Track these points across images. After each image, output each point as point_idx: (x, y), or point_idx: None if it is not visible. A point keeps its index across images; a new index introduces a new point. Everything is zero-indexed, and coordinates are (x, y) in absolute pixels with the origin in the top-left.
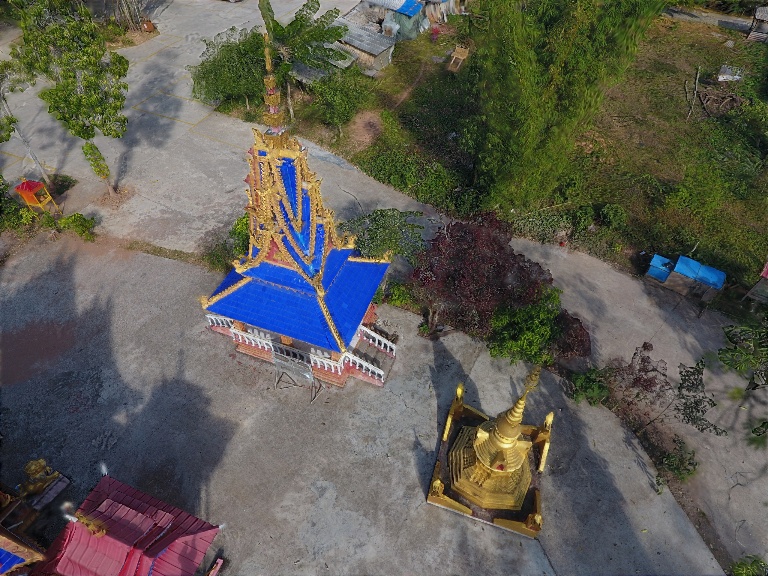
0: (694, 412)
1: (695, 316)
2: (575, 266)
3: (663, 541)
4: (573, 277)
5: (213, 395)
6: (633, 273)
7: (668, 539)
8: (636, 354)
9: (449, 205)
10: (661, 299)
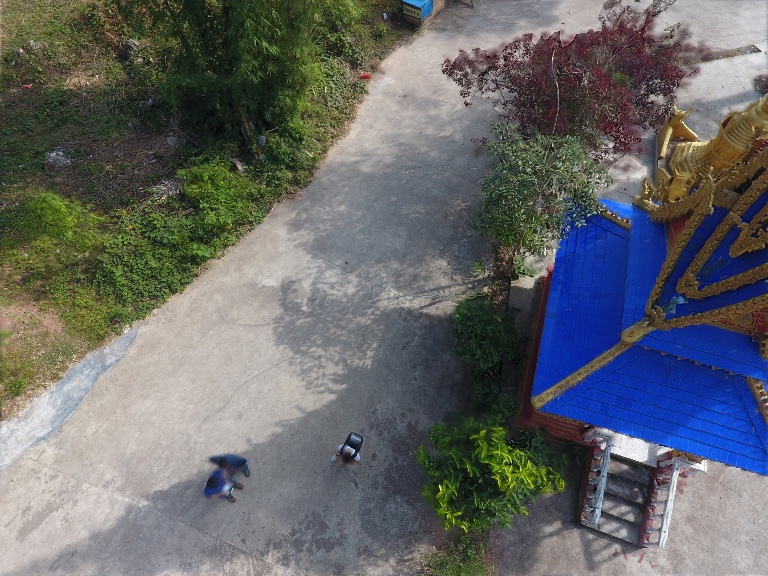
0: (666, 0)
1: (471, 8)
2: (406, 73)
3: (712, 83)
4: (426, 78)
5: (760, 500)
6: (412, 33)
7: (709, 80)
8: (605, 21)
9: (288, 176)
10: (451, 23)
